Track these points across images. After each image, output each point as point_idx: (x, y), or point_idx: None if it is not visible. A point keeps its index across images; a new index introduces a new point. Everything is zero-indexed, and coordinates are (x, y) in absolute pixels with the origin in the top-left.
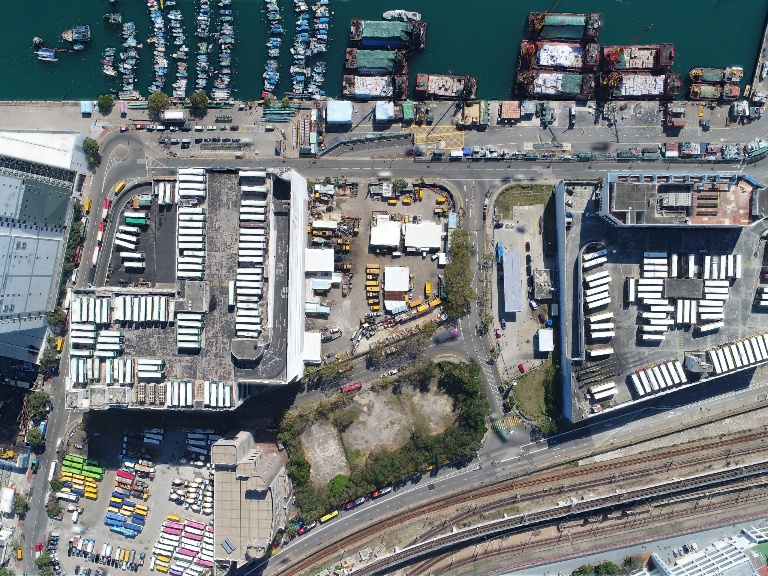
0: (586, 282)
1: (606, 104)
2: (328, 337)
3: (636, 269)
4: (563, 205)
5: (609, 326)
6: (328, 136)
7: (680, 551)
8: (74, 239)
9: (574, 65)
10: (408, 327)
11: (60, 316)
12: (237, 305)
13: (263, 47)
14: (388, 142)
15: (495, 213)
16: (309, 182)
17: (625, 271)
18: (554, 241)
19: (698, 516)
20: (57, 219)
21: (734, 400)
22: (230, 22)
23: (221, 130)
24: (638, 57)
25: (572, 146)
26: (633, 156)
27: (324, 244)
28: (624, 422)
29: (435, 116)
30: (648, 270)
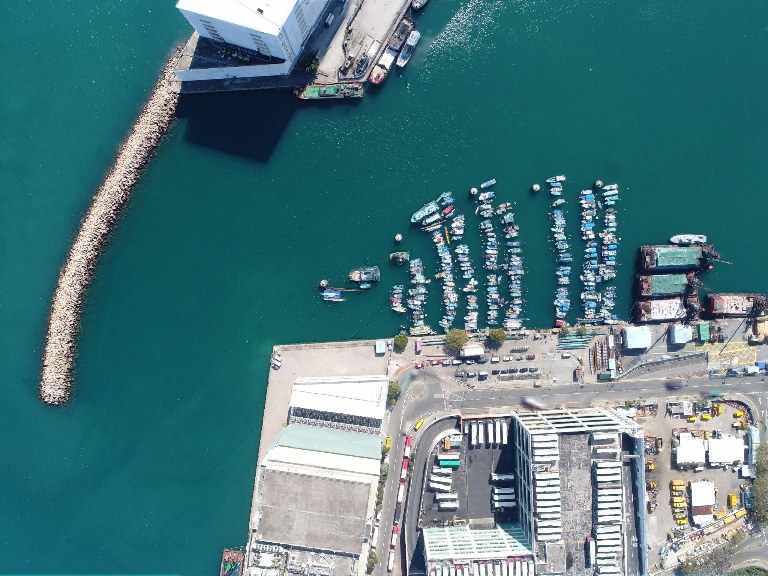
0: None
1: None
2: None
3: None
4: None
5: None
6: (624, 359)
7: None
8: (383, 482)
9: None
10: (714, 537)
11: (376, 560)
12: (597, 562)
13: (552, 275)
14: (683, 361)
15: None
16: None
17: None
18: None
19: None
20: None
21: None
22: (518, 253)
23: (517, 360)
24: None
25: None
26: None
27: None
28: None
29: (727, 333)
30: None
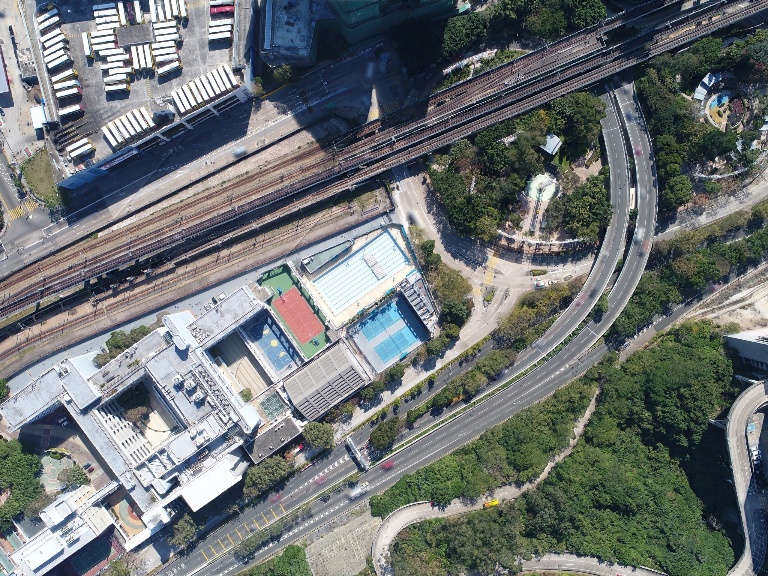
0: None
1: None
2: None
3: (93, 25)
4: None
5: (71, 83)
6: None
7: (209, 304)
8: None
9: None
10: None
11: None
12: None
13: None
14: None
15: None
16: None
17: (83, 29)
18: None
19: (221, 268)
20: None
21: (236, 149)
22: None
23: None
24: None
25: None
26: None
27: None
28: (136, 188)
29: None
30: (100, 23)
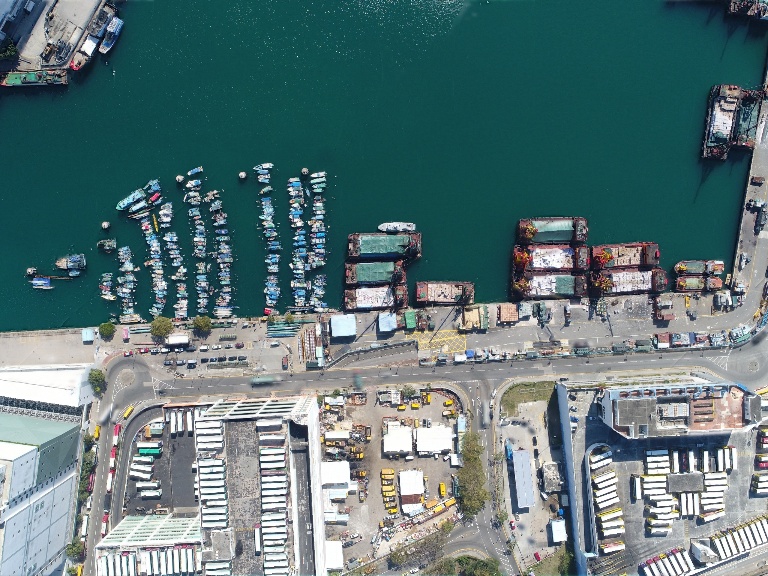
0: (595, 483)
1: (598, 301)
2: (349, 543)
3: (640, 465)
4: (567, 411)
5: (619, 524)
6: (333, 348)
7: None
8: (87, 470)
9: (566, 266)
10: (426, 526)
11: (79, 549)
12: (264, 550)
13: (262, 263)
14: (393, 350)
15: (501, 411)
16: (319, 397)
17: (630, 468)
18: (559, 434)
19: None
20: (69, 459)
21: (737, 569)
22: (227, 241)
23: (226, 348)
24: (625, 254)
25: (569, 342)
26: (628, 349)
27: (338, 453)
28: None
29: (436, 322)
30: (652, 467)
